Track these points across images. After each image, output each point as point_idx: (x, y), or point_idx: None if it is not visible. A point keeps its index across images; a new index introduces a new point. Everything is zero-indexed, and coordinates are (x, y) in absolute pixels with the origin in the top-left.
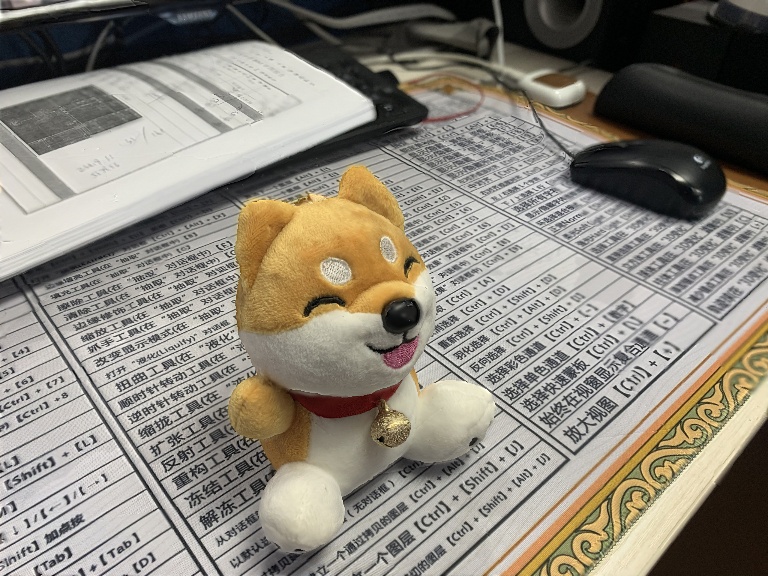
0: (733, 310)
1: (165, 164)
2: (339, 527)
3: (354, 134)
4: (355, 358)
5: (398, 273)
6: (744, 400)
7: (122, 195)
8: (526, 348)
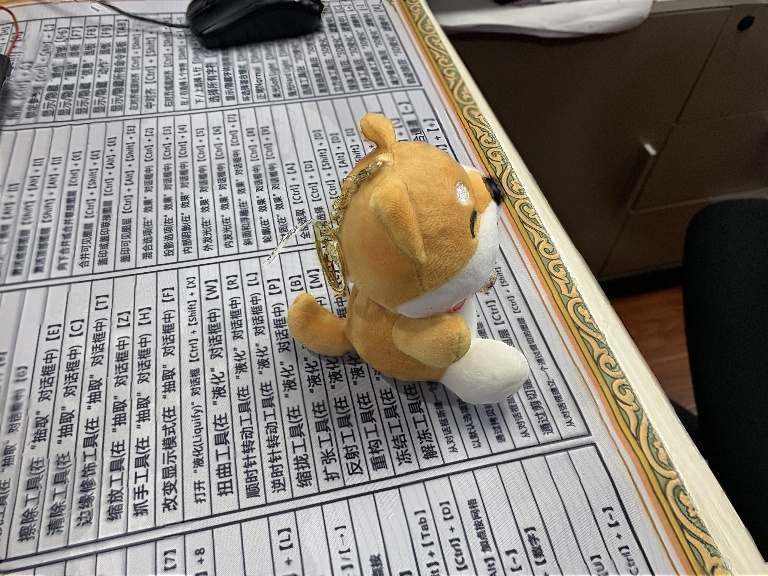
0: (418, 75)
1: None
2: None
3: None
4: None
5: None
6: (486, 122)
7: None
8: None
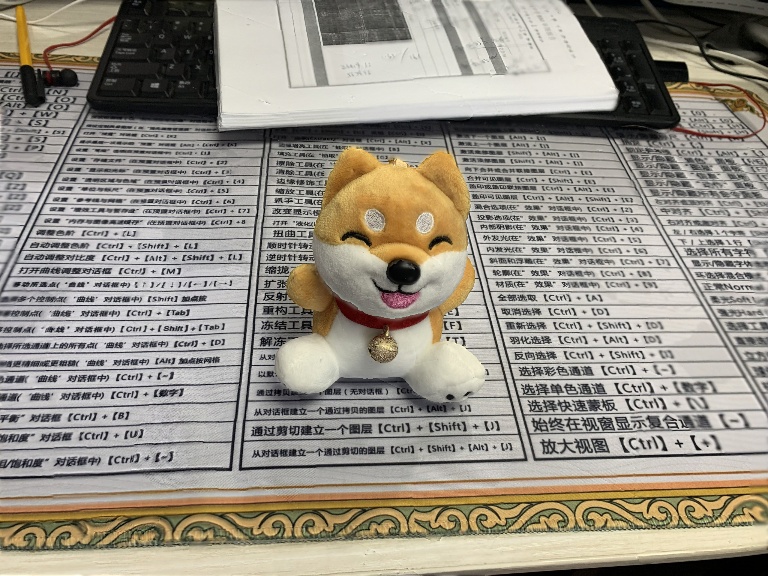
0: None
1: (403, 85)
2: (319, 389)
3: (584, 117)
4: (360, 284)
5: (422, 243)
6: (741, 524)
7: (357, 98)
8: (575, 366)
